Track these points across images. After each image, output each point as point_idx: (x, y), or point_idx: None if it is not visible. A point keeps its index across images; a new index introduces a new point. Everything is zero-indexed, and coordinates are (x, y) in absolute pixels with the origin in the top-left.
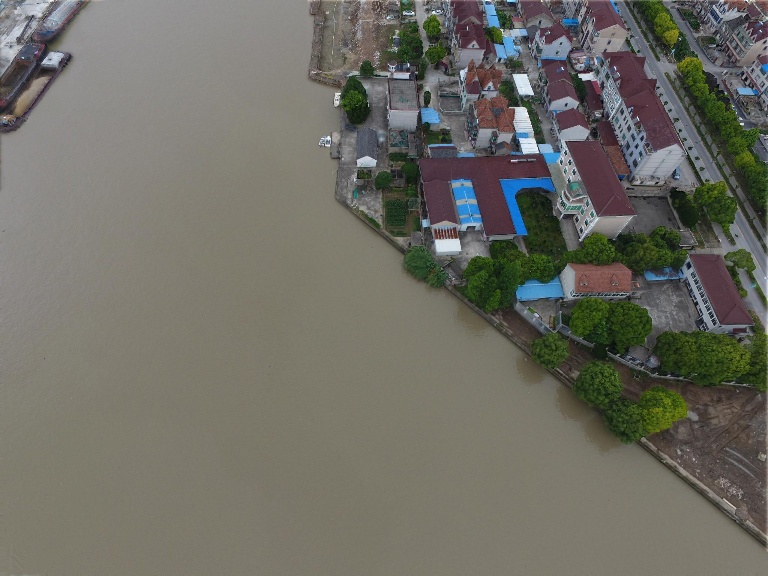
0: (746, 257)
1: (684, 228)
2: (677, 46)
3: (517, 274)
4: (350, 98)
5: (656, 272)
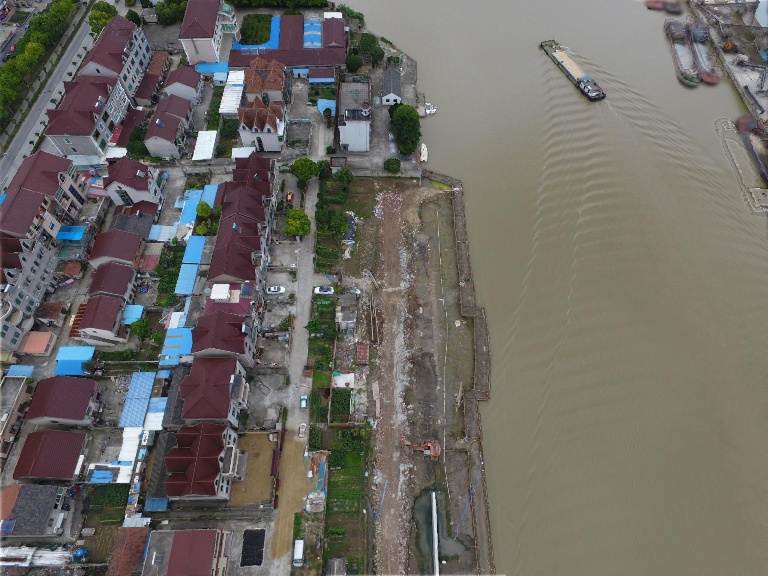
0: None
1: None
2: None
3: None
4: None
5: None
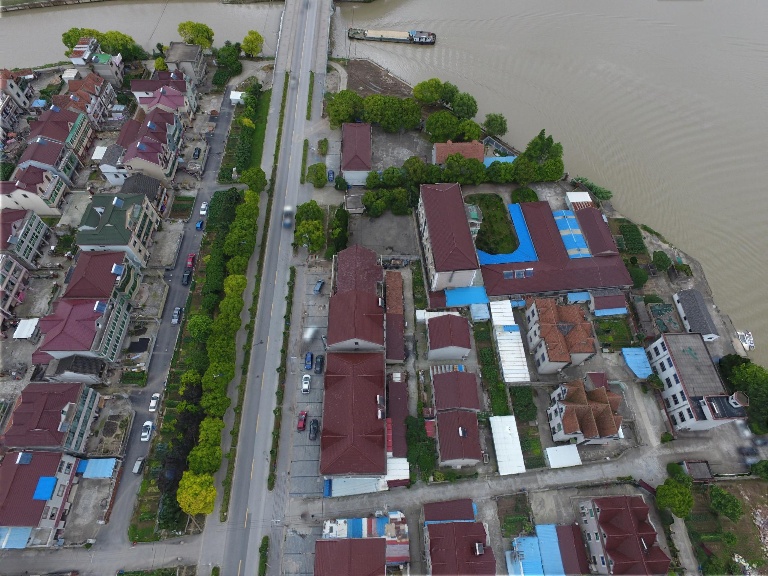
0: (316, 170)
1: None
2: None
3: None
4: (761, 368)
5: None
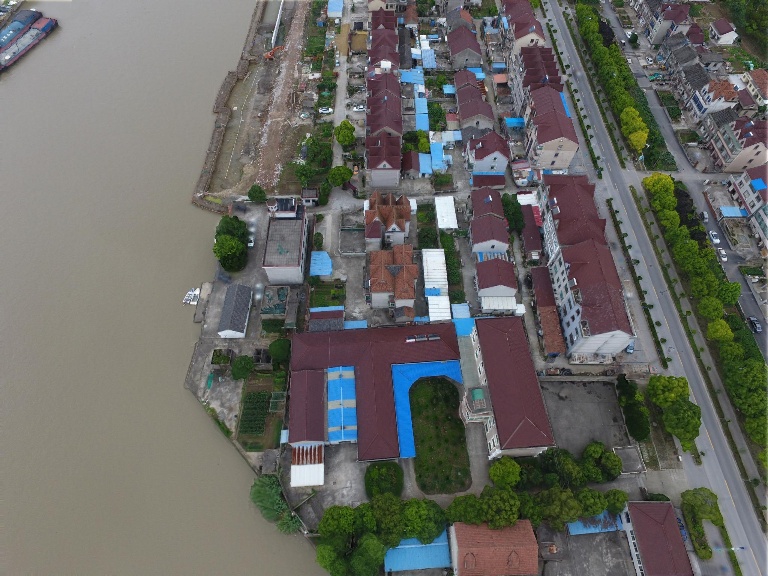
0: (709, 505)
1: (632, 438)
2: (648, 148)
3: (372, 558)
4: (220, 245)
5: (585, 519)
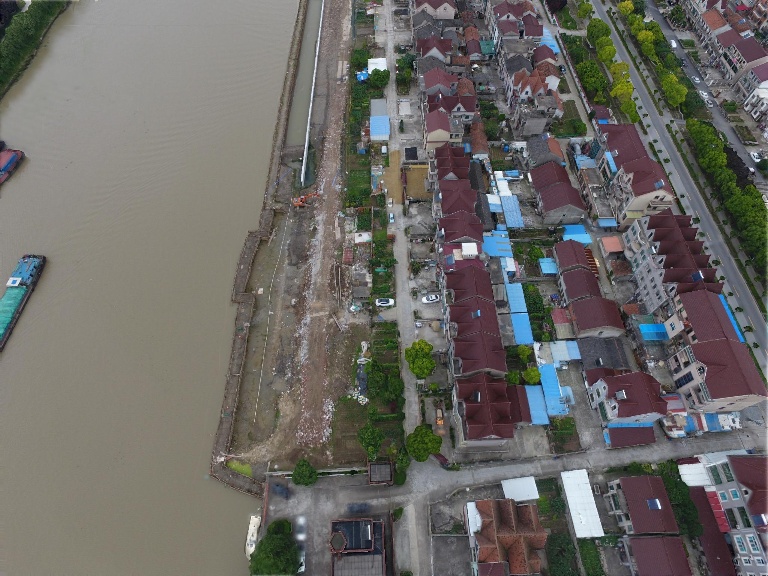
0: None
1: None
2: None
3: None
4: None
5: None
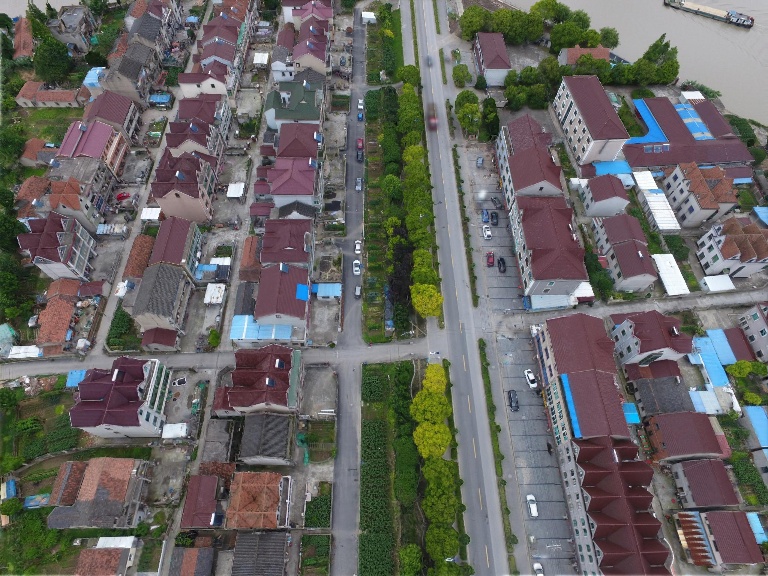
0: (463, 68)
1: None
2: None
3: None
4: None
5: None
